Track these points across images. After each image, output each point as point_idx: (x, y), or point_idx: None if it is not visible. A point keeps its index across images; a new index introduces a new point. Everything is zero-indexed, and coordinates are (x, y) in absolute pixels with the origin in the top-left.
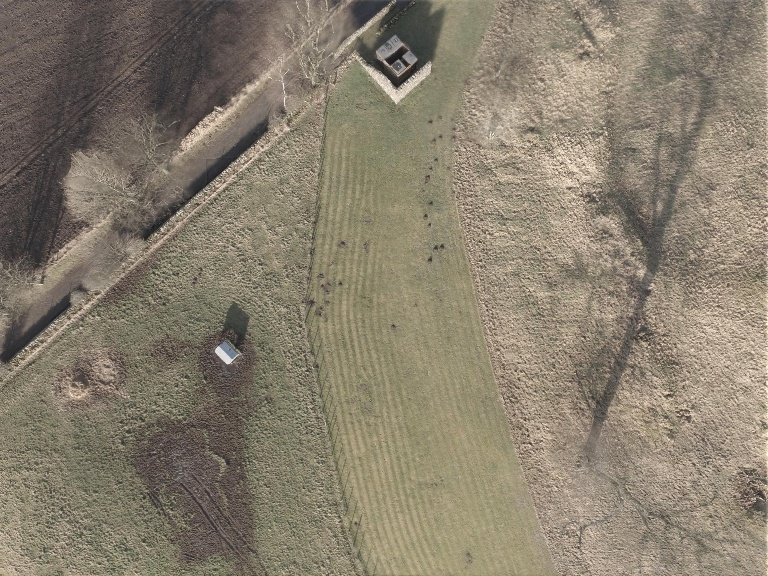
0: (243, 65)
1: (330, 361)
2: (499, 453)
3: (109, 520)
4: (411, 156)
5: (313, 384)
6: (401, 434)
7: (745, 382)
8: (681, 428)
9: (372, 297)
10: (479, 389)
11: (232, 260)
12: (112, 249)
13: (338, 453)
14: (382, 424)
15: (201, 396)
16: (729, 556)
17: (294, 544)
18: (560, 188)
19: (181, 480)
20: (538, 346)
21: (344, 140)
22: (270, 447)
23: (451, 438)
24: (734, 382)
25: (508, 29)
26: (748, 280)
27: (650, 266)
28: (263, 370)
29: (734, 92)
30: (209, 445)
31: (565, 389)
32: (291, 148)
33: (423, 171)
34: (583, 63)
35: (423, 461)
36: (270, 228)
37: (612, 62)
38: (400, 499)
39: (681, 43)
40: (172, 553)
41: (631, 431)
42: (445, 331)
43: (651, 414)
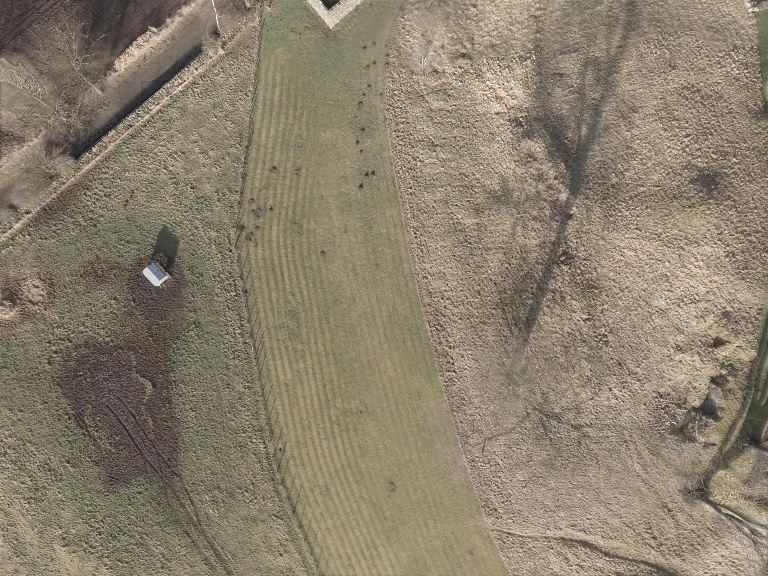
0: None
1: (259, 286)
2: (424, 381)
3: (33, 440)
4: (344, 82)
5: (241, 309)
6: (327, 361)
7: (661, 305)
8: (599, 352)
9: (302, 223)
10: (406, 317)
11: (164, 183)
12: (39, 164)
13: (264, 379)
14: (309, 350)
15: (129, 318)
16: (643, 482)
17: (218, 469)
18: (489, 114)
19: (107, 402)
20: (464, 273)
21: (278, 64)
22: (197, 371)
23: (377, 366)
24: (650, 305)
25: None
26: (665, 201)
27: (572, 189)
28: (192, 294)
29: (659, 14)
30: (136, 367)
31: (489, 316)
32: (225, 71)
33: (356, 97)
34: None
35: (349, 388)
36: (203, 152)
37: None
38: (325, 426)
39: None
40: (96, 475)
41: (551, 357)
42: (374, 258)
43: (570, 339)
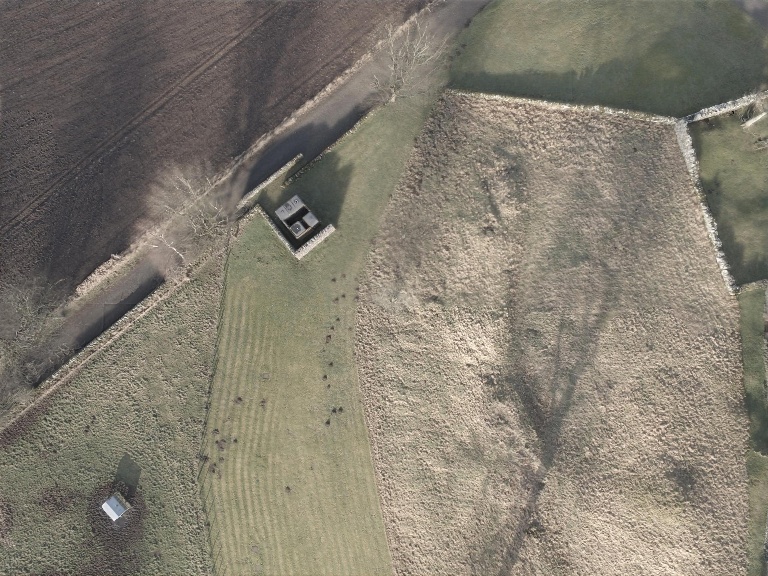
0: (144, 210)
1: (222, 520)
2: None
3: None
4: (312, 314)
5: (204, 542)
6: None
7: None
8: None
9: (267, 456)
10: (373, 560)
11: (126, 409)
12: None
13: None
14: None
15: (88, 549)
16: None
17: None
18: (460, 363)
19: None
20: (433, 523)
21: (245, 293)
22: None
23: None
24: None
25: (417, 189)
26: (640, 491)
27: (544, 460)
28: (153, 525)
29: (636, 288)
30: None
31: (458, 571)
32: (190, 298)
33: (324, 330)
34: (486, 239)
35: None
36: (166, 379)
37: (516, 240)
38: None
39: (587, 227)
40: None
41: None
42: (340, 497)
43: None
